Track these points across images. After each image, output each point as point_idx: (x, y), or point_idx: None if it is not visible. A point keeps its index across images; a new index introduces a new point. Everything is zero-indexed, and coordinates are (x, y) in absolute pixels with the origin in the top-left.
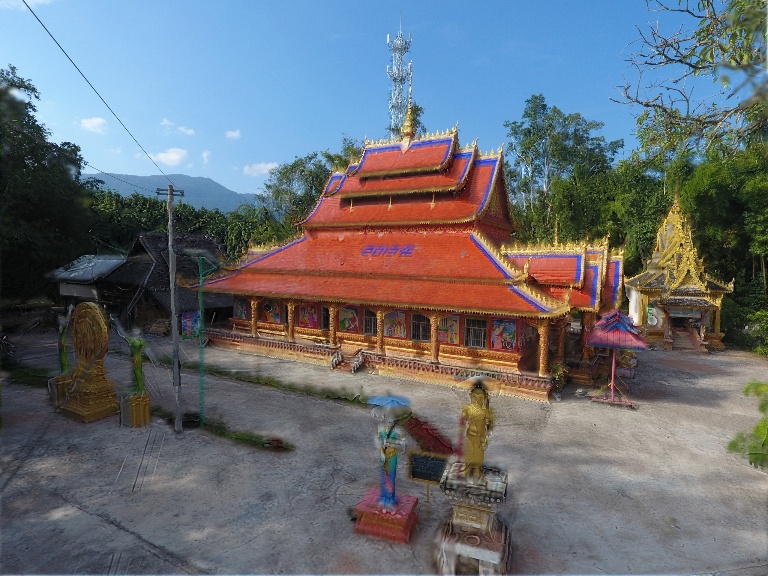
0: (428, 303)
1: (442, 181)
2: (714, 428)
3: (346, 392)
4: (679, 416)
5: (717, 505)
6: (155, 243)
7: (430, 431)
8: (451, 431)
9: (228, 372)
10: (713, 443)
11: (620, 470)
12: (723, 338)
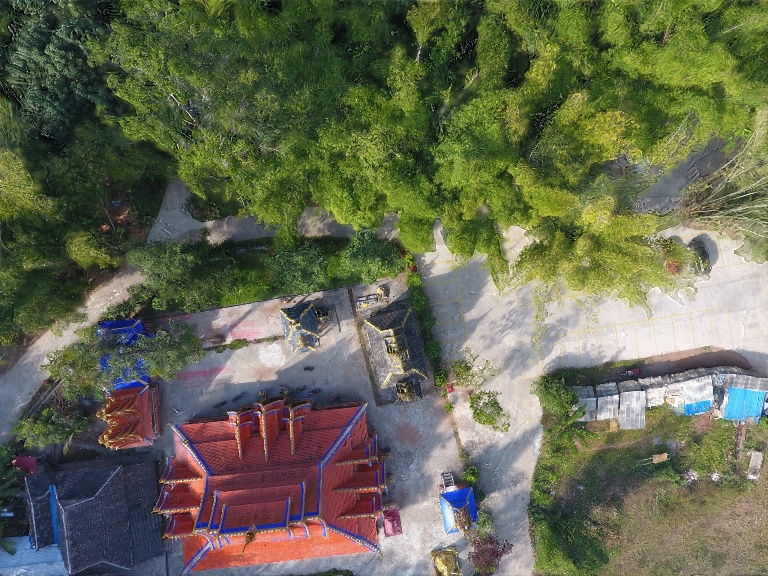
0: (329, 554)
1: (295, 532)
2: (419, 524)
3: (316, 564)
4: (410, 519)
5: (419, 574)
6: (77, 562)
7: (357, 575)
8: (362, 572)
9: (261, 574)
10: (418, 537)
11: (402, 570)
12: (423, 337)
